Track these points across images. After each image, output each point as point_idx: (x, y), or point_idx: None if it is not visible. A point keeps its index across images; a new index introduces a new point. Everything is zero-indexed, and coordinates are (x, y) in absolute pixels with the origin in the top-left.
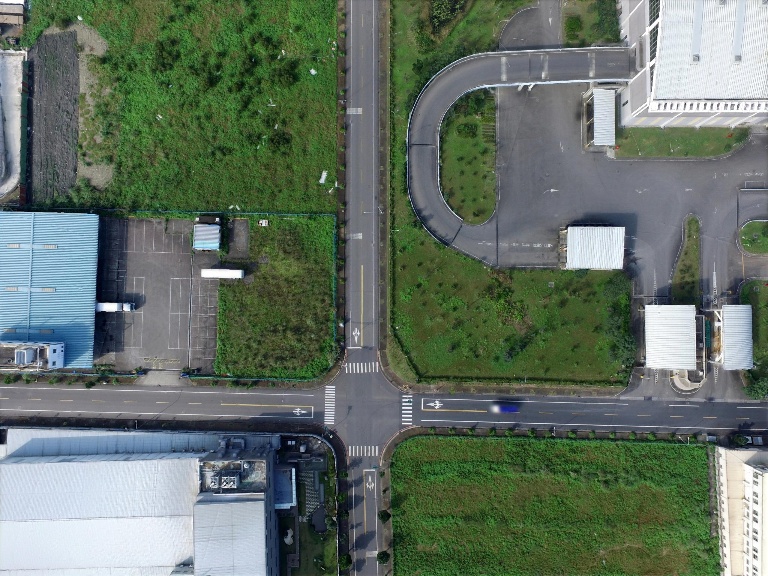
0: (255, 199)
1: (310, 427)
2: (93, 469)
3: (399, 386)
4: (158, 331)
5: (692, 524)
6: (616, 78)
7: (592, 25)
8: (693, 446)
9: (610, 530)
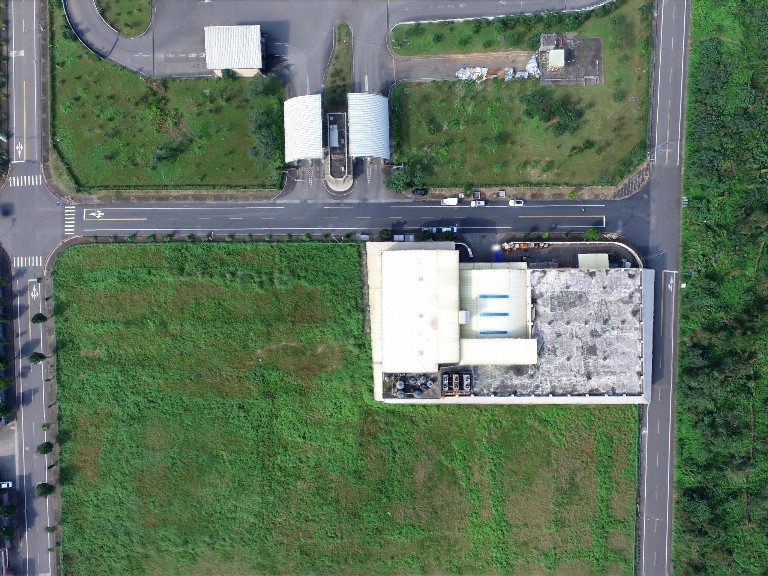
0: None
1: None
2: None
3: (62, 197)
4: None
5: (345, 321)
6: None
7: None
8: (345, 245)
9: (265, 329)
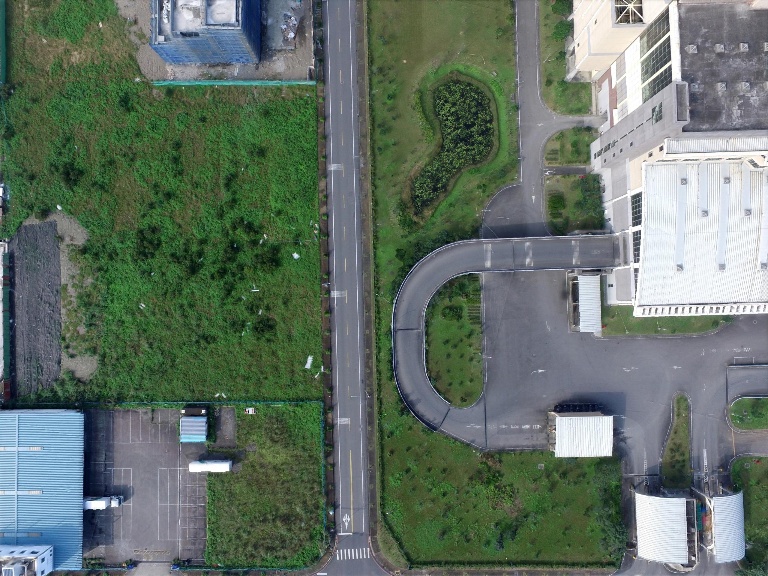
0: (241, 387)
1: None
2: None
3: (391, 571)
4: (147, 523)
5: None
6: (601, 265)
7: (576, 204)
8: None
9: None
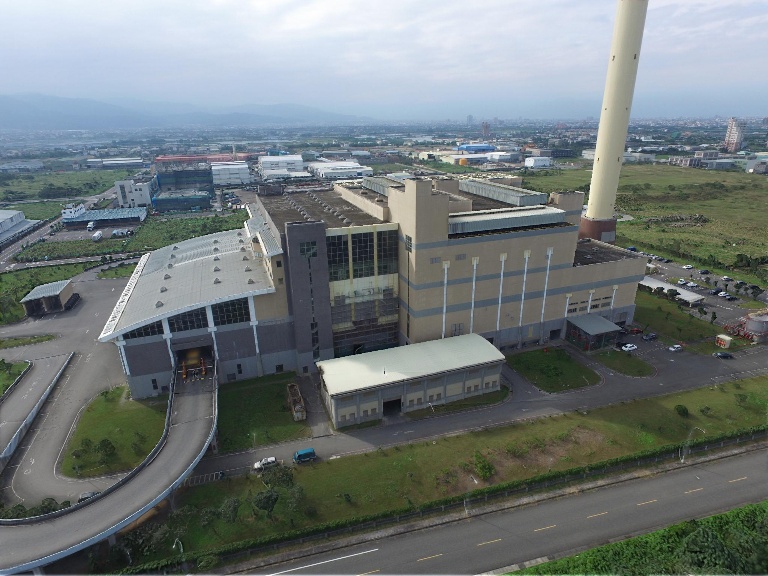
0: None
1: None
2: (1, 219)
3: None
4: None
5: None
6: None
7: None
8: None
9: None
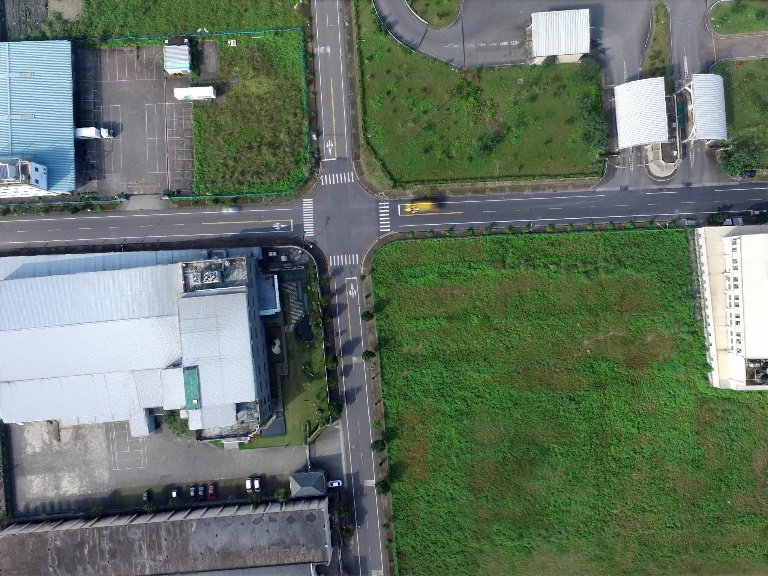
0: (222, 20)
1: (290, 240)
2: (81, 279)
3: (375, 194)
4: (137, 157)
5: (675, 308)
6: None
7: None
8: (672, 231)
9: (593, 319)
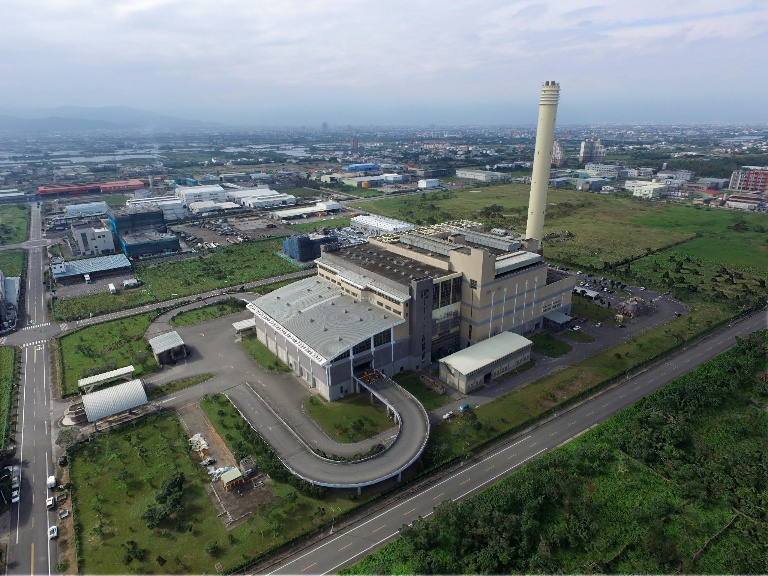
0: None
1: None
2: None
3: None
4: None
5: None
6: None
7: None
8: (2, 442)
9: None
